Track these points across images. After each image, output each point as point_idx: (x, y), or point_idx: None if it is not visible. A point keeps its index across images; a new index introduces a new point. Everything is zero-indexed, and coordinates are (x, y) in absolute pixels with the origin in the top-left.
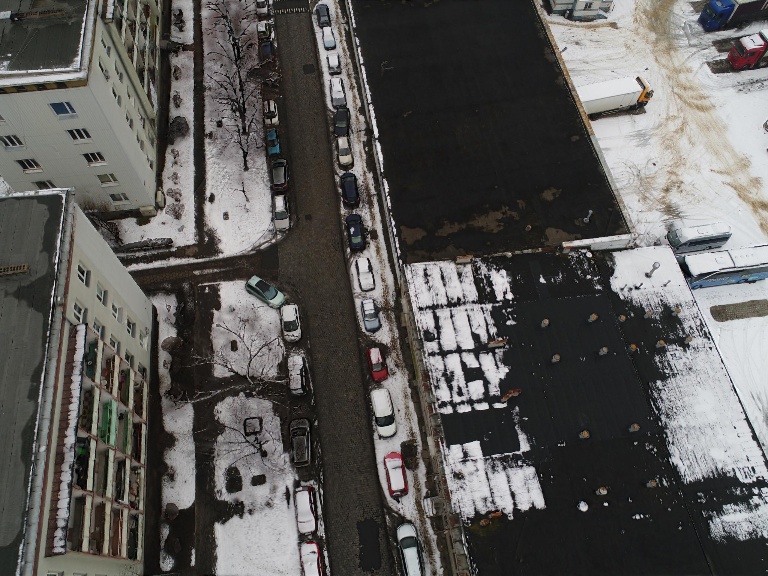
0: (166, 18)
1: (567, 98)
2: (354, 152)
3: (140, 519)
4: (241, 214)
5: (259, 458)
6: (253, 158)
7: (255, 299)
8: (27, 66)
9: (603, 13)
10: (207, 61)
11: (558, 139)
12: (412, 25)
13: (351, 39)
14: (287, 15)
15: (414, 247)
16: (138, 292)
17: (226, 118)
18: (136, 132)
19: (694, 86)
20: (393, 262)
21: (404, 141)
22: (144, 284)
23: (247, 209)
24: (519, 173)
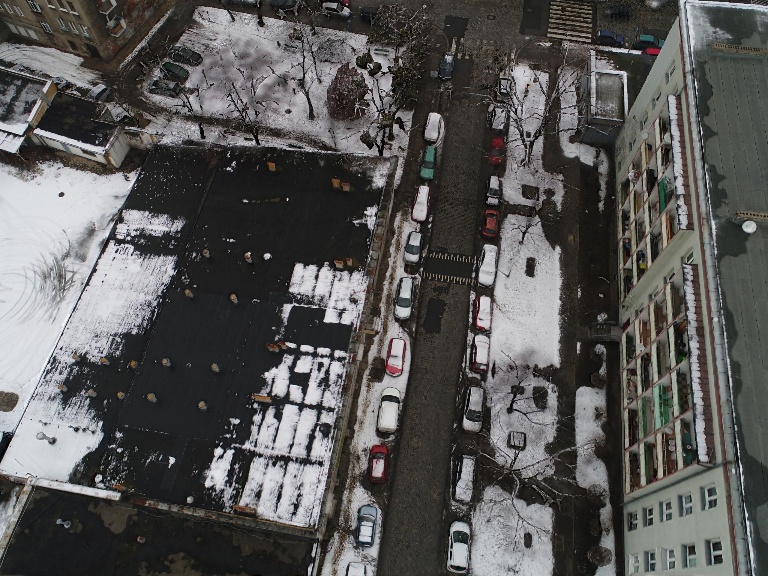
0: None
1: None
2: None
3: (625, 364)
4: None
5: None
6: None
7: None
8: None
9: None
10: None
11: None
12: None
13: None
14: None
15: (289, 570)
16: None
17: None
18: None
19: None
20: None
21: None
22: None
23: None
24: None
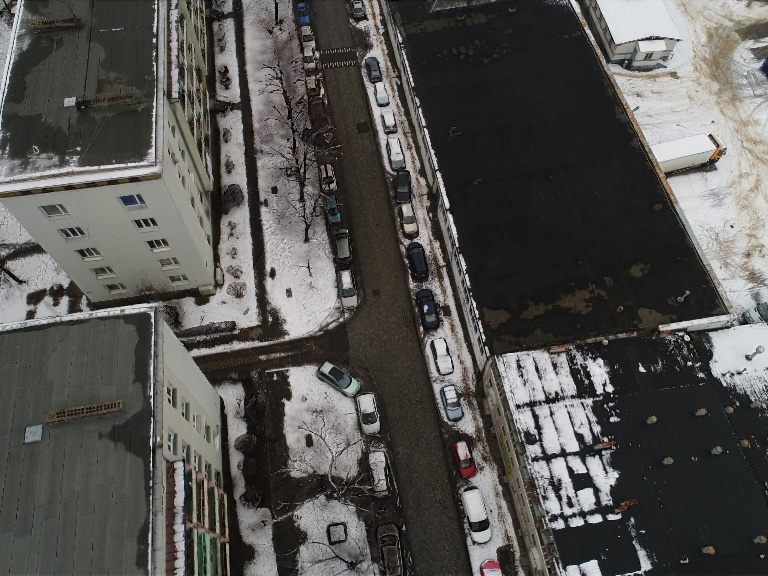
0: (210, 75)
1: (644, 162)
2: (418, 219)
3: None
4: (305, 291)
5: (346, 571)
6: (313, 228)
7: (327, 387)
8: (99, 161)
9: (663, 62)
10: (256, 121)
11: (640, 208)
12: (473, 83)
13: (404, 94)
14: (335, 69)
15: (499, 332)
16: (209, 389)
17: (281, 184)
18: (197, 210)
19: (764, 140)
20: (470, 341)
21: (477, 212)
22: (208, 372)
23: (313, 287)
24: (603, 246)
